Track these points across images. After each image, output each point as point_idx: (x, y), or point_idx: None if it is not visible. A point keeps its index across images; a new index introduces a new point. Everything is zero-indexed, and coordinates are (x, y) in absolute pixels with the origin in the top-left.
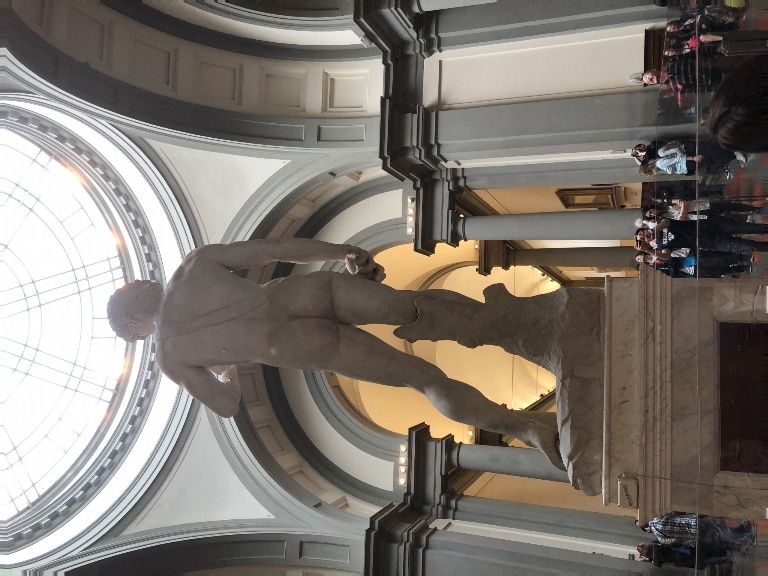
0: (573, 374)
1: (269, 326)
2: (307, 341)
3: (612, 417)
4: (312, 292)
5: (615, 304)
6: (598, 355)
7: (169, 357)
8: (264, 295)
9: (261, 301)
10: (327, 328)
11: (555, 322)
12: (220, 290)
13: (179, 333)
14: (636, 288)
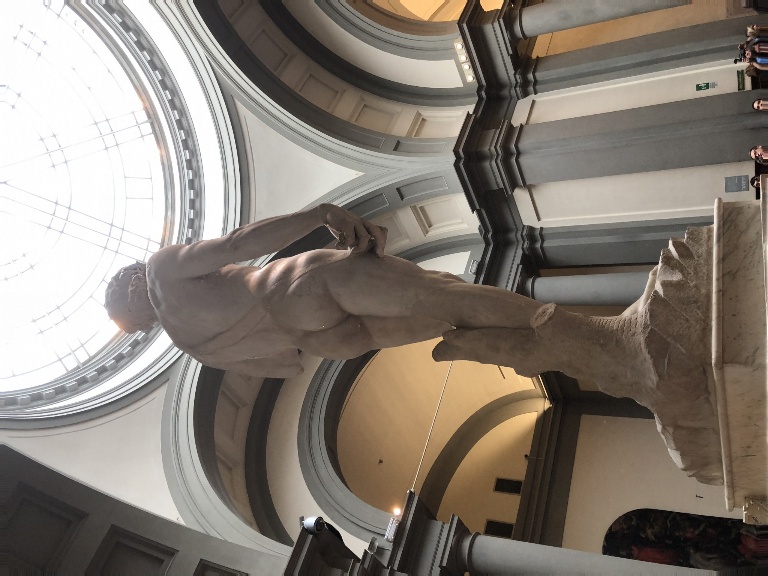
0: (676, 424)
1: (286, 336)
2: (337, 356)
3: (734, 464)
4: (313, 317)
5: (730, 386)
6: (709, 413)
7: (206, 362)
8: (260, 308)
9: (261, 314)
10: (351, 336)
11: (643, 388)
12: (210, 316)
13: (200, 354)
14: (763, 373)
